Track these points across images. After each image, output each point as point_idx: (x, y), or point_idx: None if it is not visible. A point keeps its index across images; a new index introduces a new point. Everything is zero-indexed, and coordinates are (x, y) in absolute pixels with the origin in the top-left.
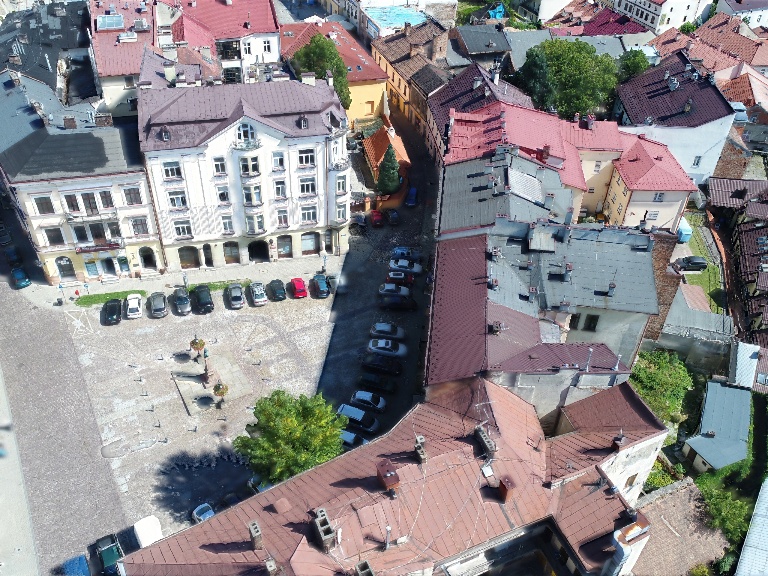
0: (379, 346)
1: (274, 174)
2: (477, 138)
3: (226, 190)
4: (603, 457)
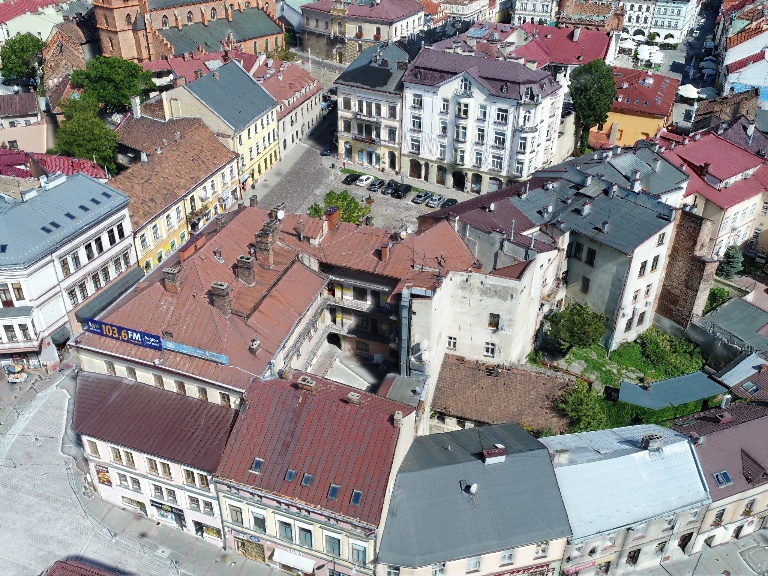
0: None
1: (478, 122)
2: None
3: (447, 125)
4: None
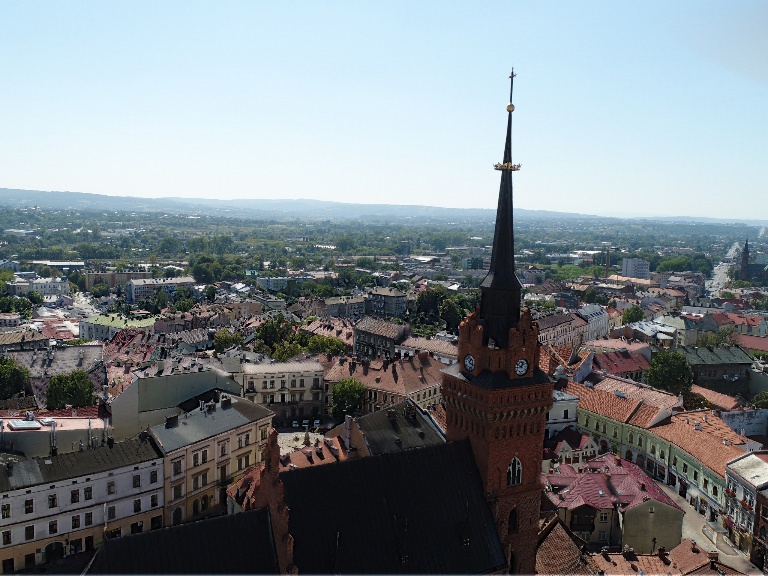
0: None
1: None
2: None
3: None
4: None
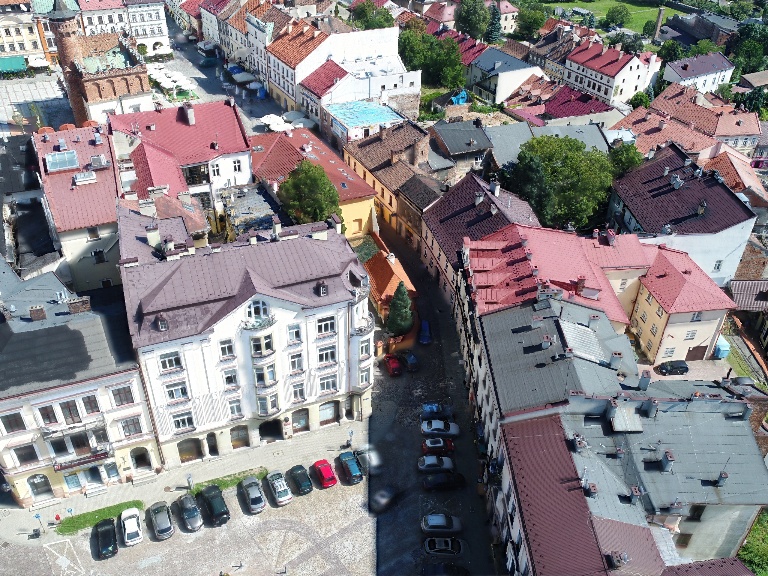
0: (438, 549)
1: (289, 348)
2: (503, 273)
3: (234, 373)
4: None
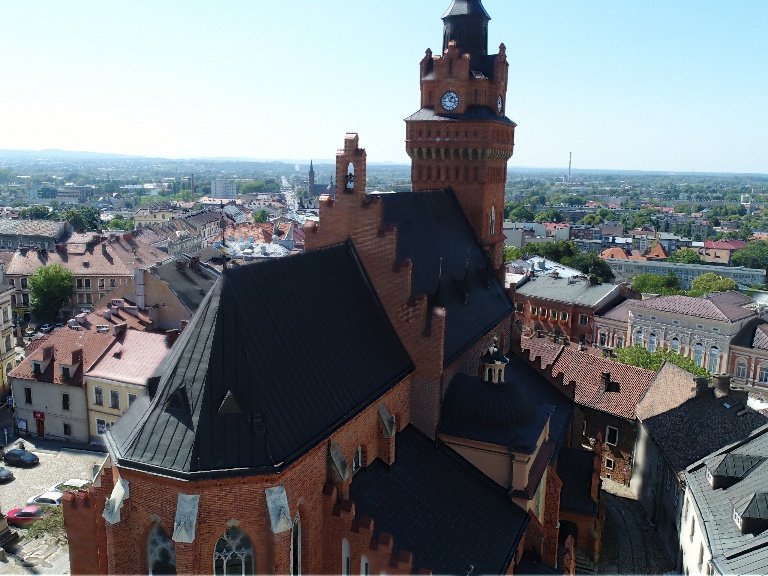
0: None
1: None
2: None
3: None
4: (2, 252)
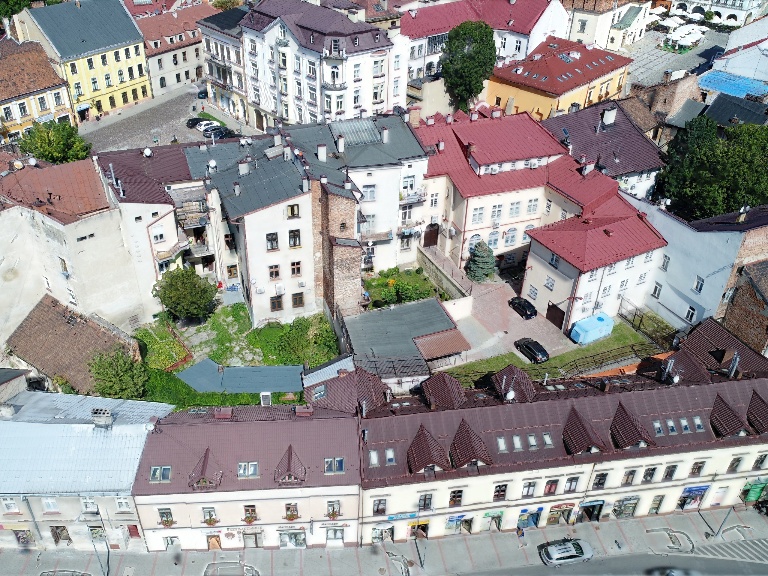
0: None
1: (296, 74)
2: None
3: None
4: None
